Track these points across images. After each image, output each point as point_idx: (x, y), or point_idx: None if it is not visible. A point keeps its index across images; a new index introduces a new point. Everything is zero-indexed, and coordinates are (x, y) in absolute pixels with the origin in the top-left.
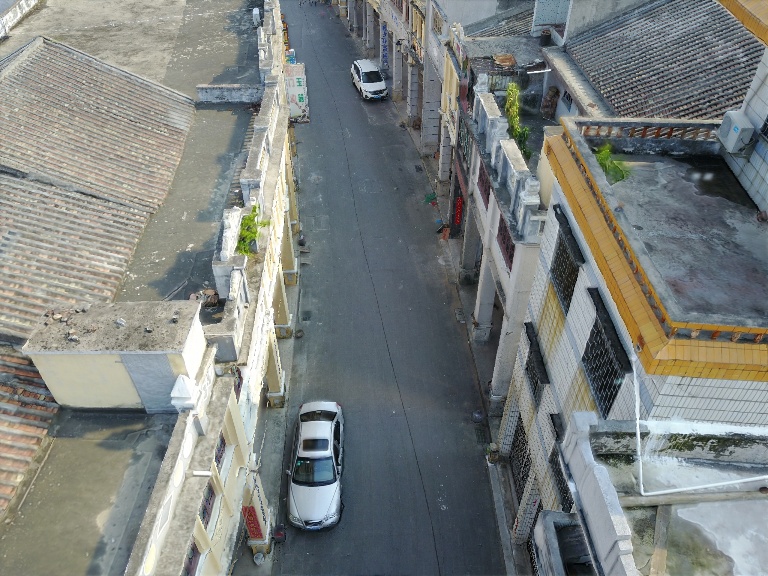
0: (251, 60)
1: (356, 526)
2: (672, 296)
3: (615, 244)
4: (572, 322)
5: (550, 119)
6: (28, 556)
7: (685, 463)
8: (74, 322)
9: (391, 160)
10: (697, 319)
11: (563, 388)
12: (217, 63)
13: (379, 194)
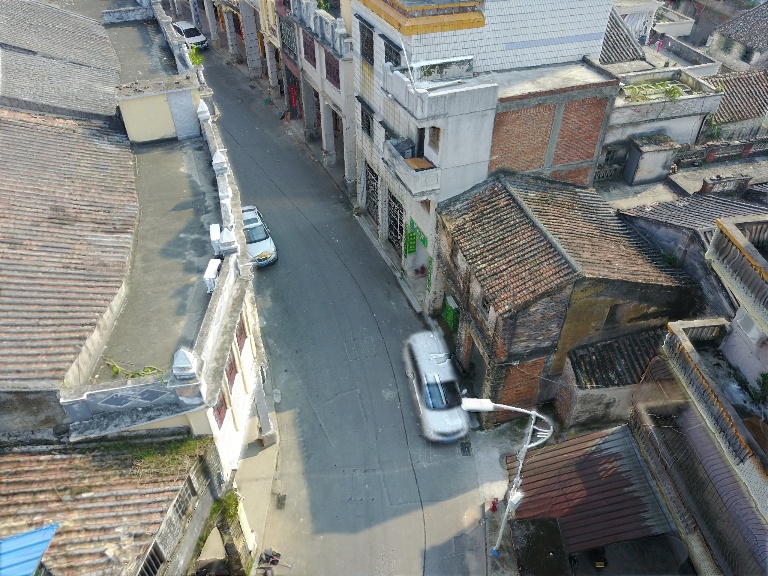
0: (123, 0)
1: (288, 260)
2: (405, 3)
3: (383, 2)
4: (376, 65)
5: (339, 8)
6: (155, 183)
7: (431, 82)
8: (135, 87)
9: (229, 85)
10: (415, 6)
11: (381, 104)
12: (99, 5)
13: (229, 106)
